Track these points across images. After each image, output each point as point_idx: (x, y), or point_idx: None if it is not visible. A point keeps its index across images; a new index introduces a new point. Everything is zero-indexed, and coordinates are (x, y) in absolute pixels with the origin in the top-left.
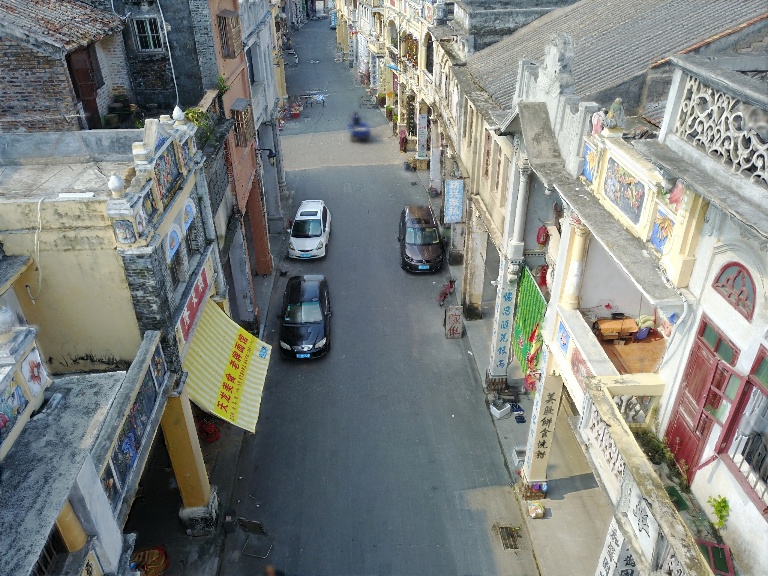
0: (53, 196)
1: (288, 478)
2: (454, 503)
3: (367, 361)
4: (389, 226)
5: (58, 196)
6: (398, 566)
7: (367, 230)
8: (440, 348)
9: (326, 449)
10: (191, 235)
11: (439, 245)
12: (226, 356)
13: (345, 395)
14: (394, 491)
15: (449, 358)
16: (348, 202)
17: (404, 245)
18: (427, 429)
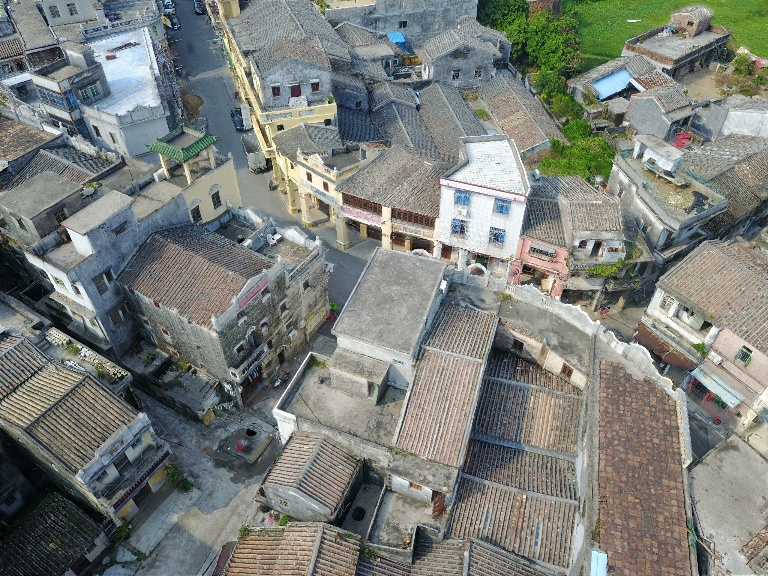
0: None
1: (178, 42)
2: (206, 41)
3: (189, 29)
4: (191, 6)
5: None
6: (198, 46)
7: (185, 8)
8: (205, 26)
9: (184, 39)
10: None
11: (204, 7)
12: (163, 19)
13: (186, 33)
14: (196, 41)
15: (207, 27)
16: (178, 1)
17: (195, 8)
18: (202, 35)
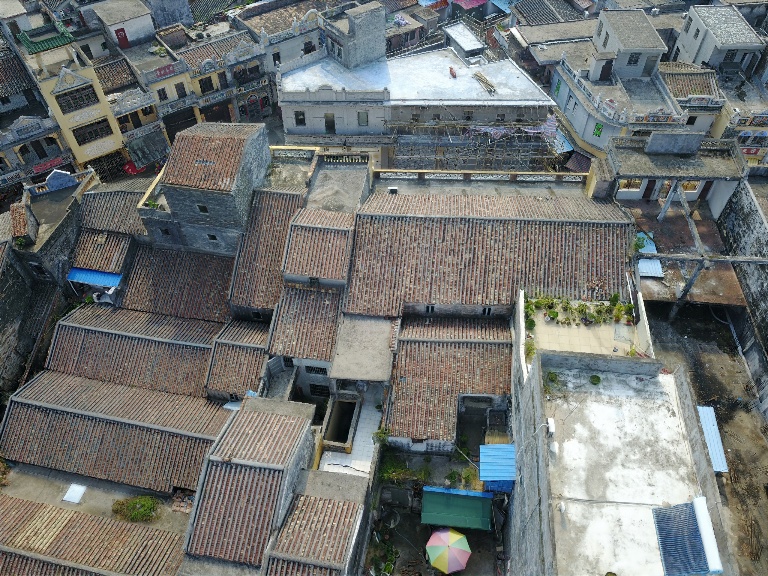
0: (747, 109)
1: None
2: None
3: None
4: None
5: (747, 109)
6: None
7: None
8: None
9: None
10: (763, 140)
11: None
12: None
13: None
14: None
15: None
16: None
17: None
18: None
